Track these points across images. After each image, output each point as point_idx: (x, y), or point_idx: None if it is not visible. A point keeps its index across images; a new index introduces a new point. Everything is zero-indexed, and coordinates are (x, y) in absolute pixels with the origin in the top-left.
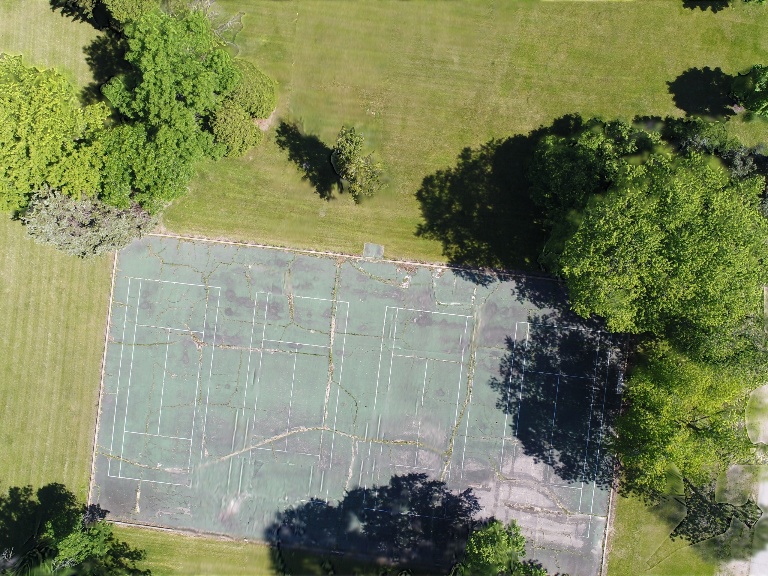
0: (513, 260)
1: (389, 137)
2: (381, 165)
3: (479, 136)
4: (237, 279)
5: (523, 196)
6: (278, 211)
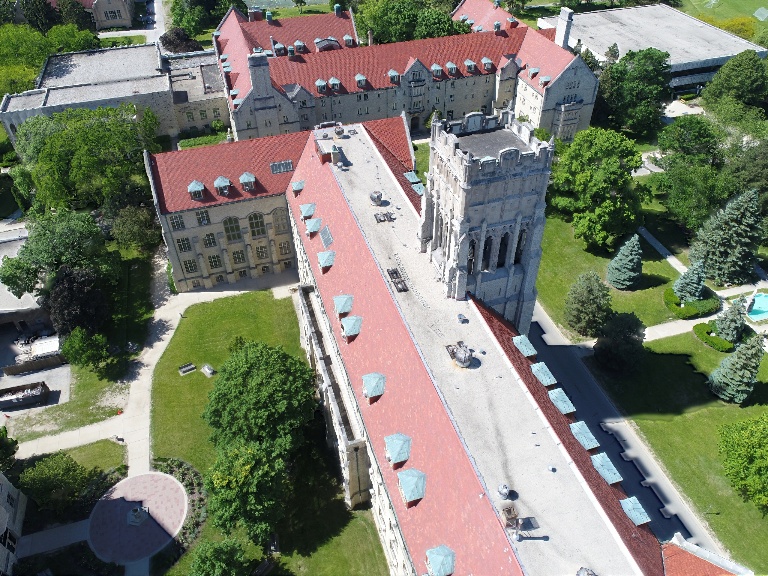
0: None
1: None
2: None
3: None
4: (326, 0)
5: None
6: (321, 7)
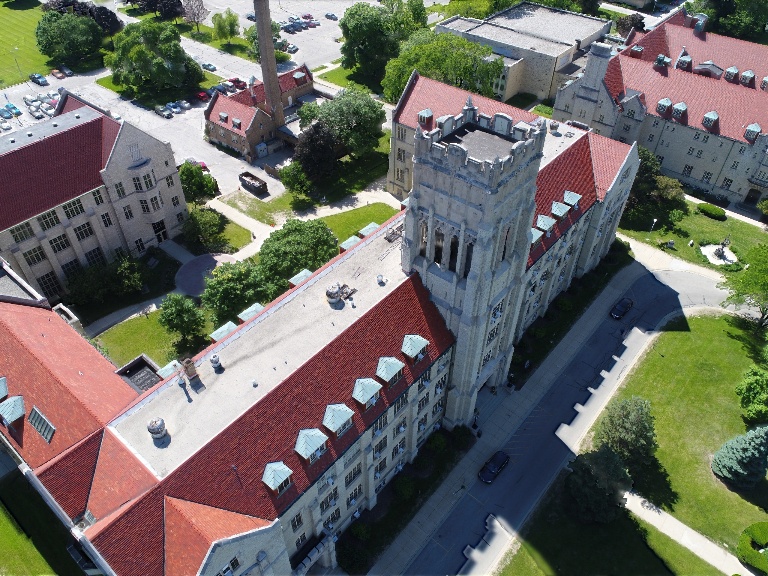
0: None
1: None
2: None
3: None
4: None
5: (762, 39)
6: None
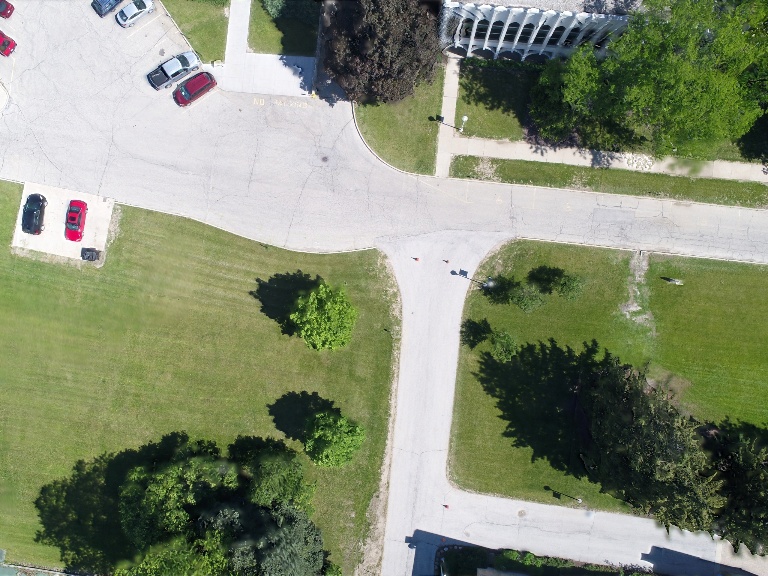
0: (126, 568)
1: (9, 447)
2: (2, 473)
3: (93, 449)
4: None
5: None
6: None
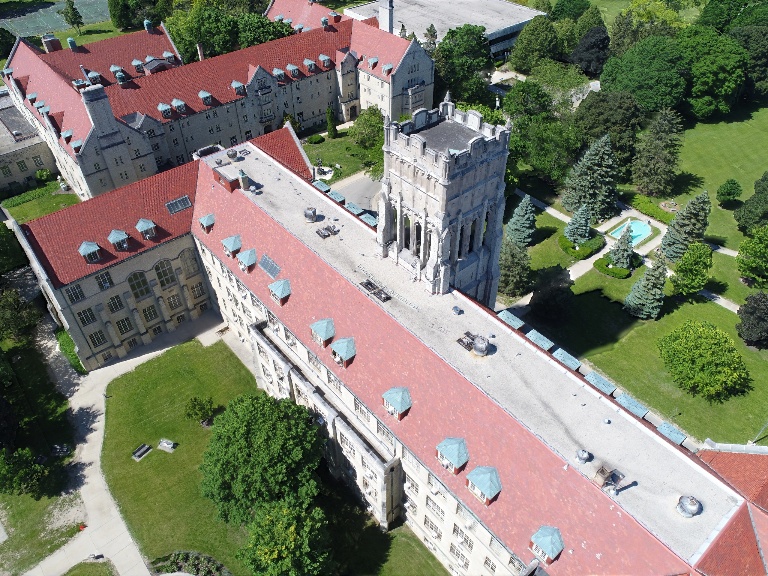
0: None
1: None
2: None
3: None
4: None
5: None
6: None
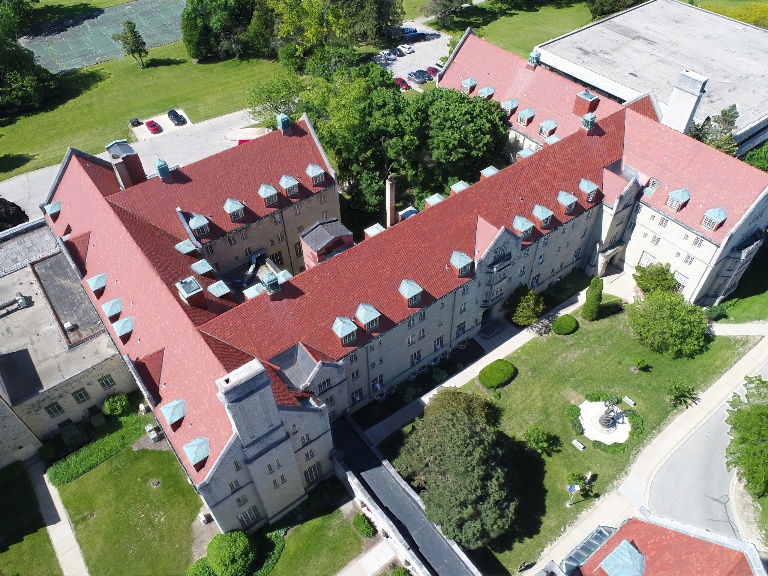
0: None
1: None
2: None
3: None
4: None
5: None
6: None
